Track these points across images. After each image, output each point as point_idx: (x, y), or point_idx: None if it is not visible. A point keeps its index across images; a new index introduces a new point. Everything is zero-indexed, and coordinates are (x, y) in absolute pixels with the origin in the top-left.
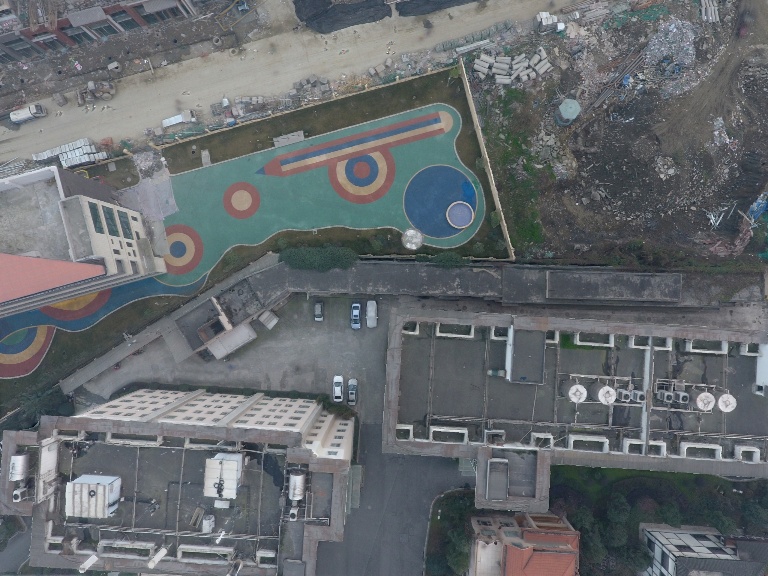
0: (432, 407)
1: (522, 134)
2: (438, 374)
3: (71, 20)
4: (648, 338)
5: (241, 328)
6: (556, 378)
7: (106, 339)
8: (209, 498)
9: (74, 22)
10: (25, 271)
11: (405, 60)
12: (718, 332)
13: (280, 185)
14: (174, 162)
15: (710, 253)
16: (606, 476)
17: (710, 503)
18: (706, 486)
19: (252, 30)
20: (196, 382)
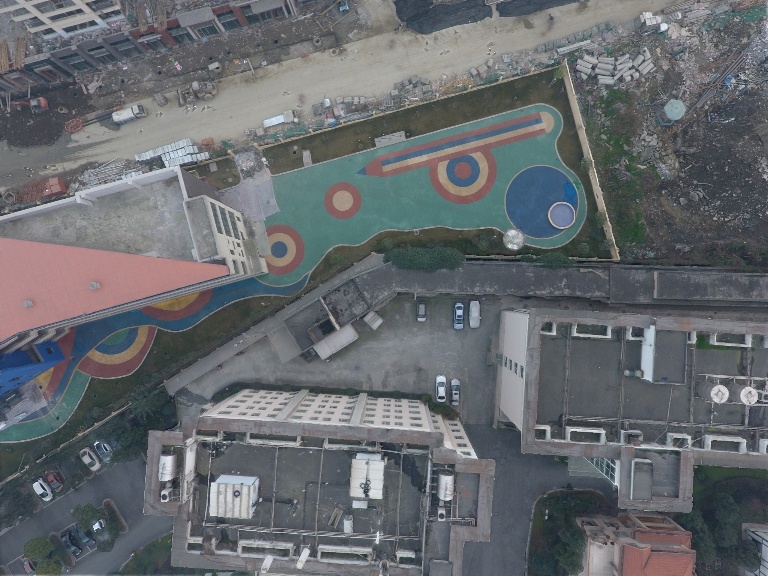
0: (568, 407)
1: (624, 134)
2: (573, 374)
3: (180, 20)
4: None
5: (347, 328)
6: (692, 378)
7: (208, 339)
8: (347, 498)
9: (183, 22)
10: (150, 271)
11: (506, 60)
12: None
13: (381, 185)
14: (275, 162)
15: None
16: (709, 476)
17: None
18: None
19: (352, 30)
20: (298, 382)
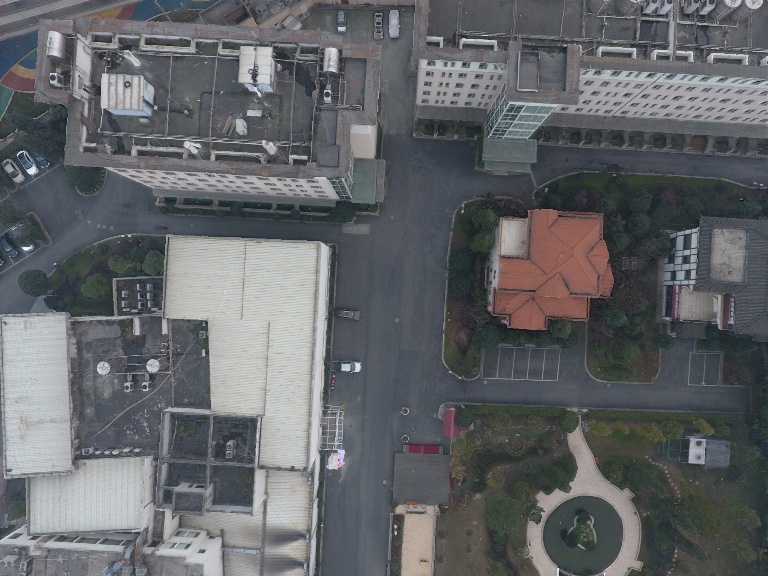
0: (461, 23)
1: None
2: None
3: None
4: None
5: None
6: None
7: None
8: (241, 108)
9: None
10: None
11: None
12: None
13: None
14: None
15: None
16: None
17: None
18: (726, 193)
19: None
20: None
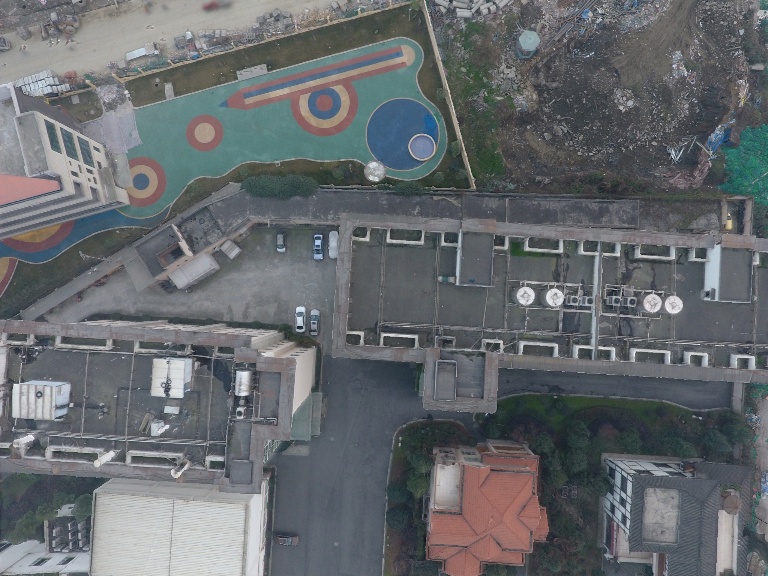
0: (383, 314)
1: (483, 67)
2: (389, 281)
3: None
4: (597, 244)
5: (202, 257)
6: (506, 284)
7: (68, 271)
8: (159, 404)
9: None
10: None
11: None
12: (665, 236)
13: (243, 118)
14: (137, 95)
15: (670, 185)
16: (568, 406)
17: (671, 432)
18: (667, 416)
19: None
20: (158, 314)
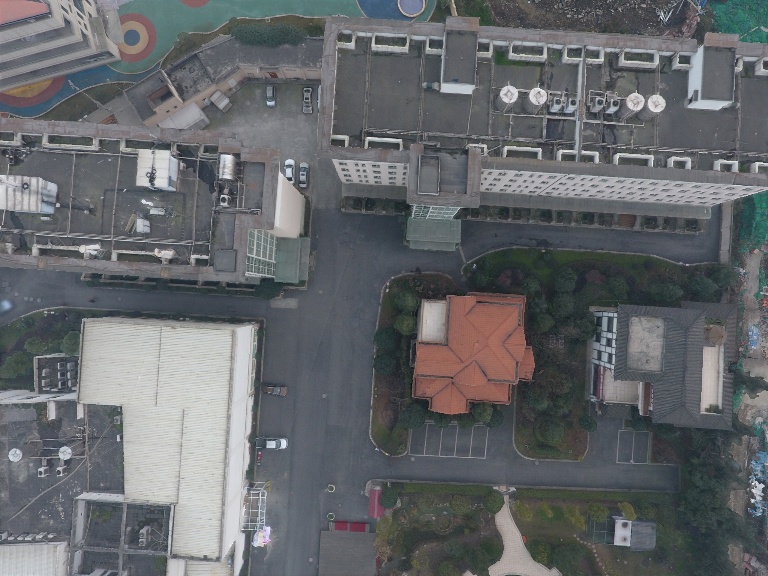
0: (368, 120)
1: None
2: (374, 89)
3: None
4: (581, 52)
5: (192, 106)
6: (490, 91)
7: None
8: (145, 206)
9: None
10: None
11: None
12: (649, 40)
13: None
14: None
15: None
16: (556, 260)
17: None
18: (655, 270)
19: None
20: None
